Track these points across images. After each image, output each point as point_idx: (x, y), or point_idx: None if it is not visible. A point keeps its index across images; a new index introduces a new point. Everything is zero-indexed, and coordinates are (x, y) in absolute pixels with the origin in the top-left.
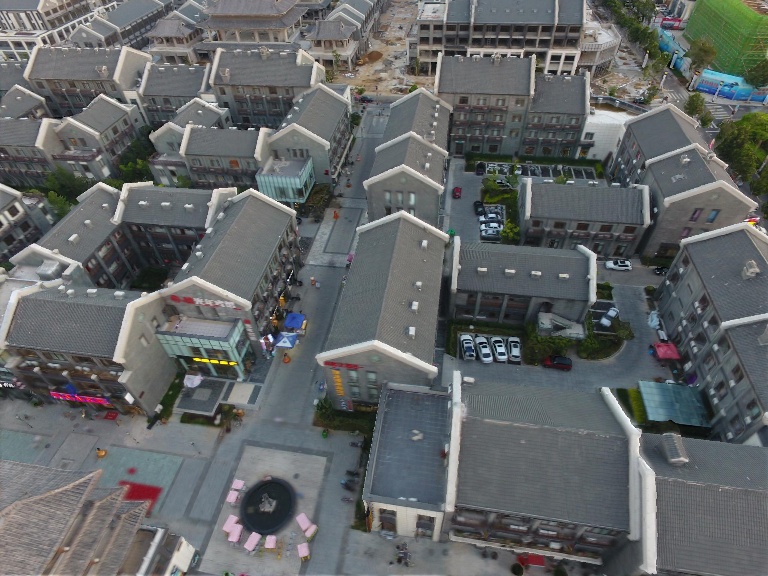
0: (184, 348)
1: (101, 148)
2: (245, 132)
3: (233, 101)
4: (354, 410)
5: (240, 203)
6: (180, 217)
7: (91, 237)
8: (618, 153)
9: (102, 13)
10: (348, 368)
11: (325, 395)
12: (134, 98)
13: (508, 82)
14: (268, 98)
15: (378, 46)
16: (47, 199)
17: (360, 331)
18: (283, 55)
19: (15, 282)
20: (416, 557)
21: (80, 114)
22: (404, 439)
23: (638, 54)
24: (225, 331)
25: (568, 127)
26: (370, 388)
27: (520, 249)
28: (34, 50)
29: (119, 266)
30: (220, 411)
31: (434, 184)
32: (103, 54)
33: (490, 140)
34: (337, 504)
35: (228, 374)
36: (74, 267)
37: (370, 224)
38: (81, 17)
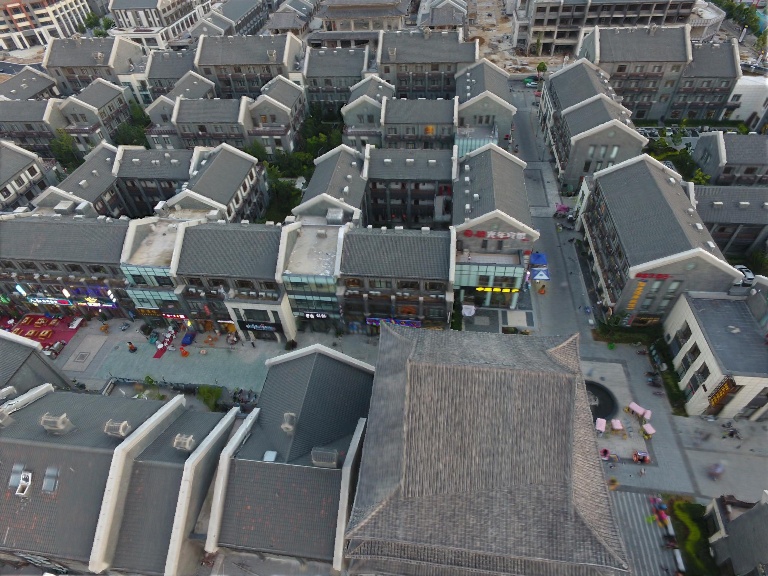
0: (474, 278)
1: (290, 123)
2: (439, 101)
3: (395, 79)
4: (631, 325)
5: (482, 156)
6: (424, 172)
7: (355, 190)
8: (767, 112)
9: (218, 8)
10: (657, 279)
11: (594, 317)
12: (298, 80)
13: (665, 50)
14: (429, 75)
15: (476, 32)
16: (265, 167)
17: (667, 246)
18: (445, 34)
19: (311, 227)
20: (741, 433)
21: (270, 93)
22: (724, 333)
23: (729, 30)
24: (509, 261)
25: (718, 90)
26: (665, 299)
27: (740, 187)
28: (201, 39)
29: (363, 219)
30: (507, 332)
31: (641, 136)
32: (268, 40)
33: (640, 106)
34: (651, 398)
35: (499, 303)
36: (359, 213)
37: (611, 168)
38: (187, 14)
